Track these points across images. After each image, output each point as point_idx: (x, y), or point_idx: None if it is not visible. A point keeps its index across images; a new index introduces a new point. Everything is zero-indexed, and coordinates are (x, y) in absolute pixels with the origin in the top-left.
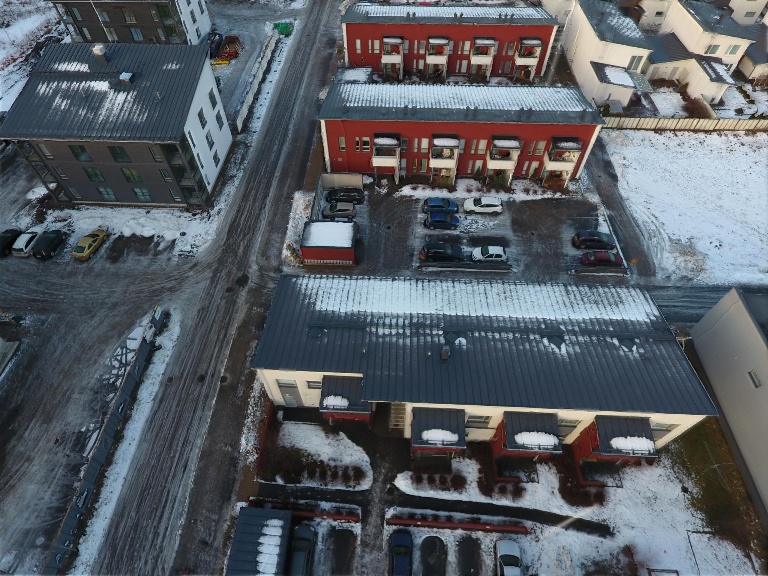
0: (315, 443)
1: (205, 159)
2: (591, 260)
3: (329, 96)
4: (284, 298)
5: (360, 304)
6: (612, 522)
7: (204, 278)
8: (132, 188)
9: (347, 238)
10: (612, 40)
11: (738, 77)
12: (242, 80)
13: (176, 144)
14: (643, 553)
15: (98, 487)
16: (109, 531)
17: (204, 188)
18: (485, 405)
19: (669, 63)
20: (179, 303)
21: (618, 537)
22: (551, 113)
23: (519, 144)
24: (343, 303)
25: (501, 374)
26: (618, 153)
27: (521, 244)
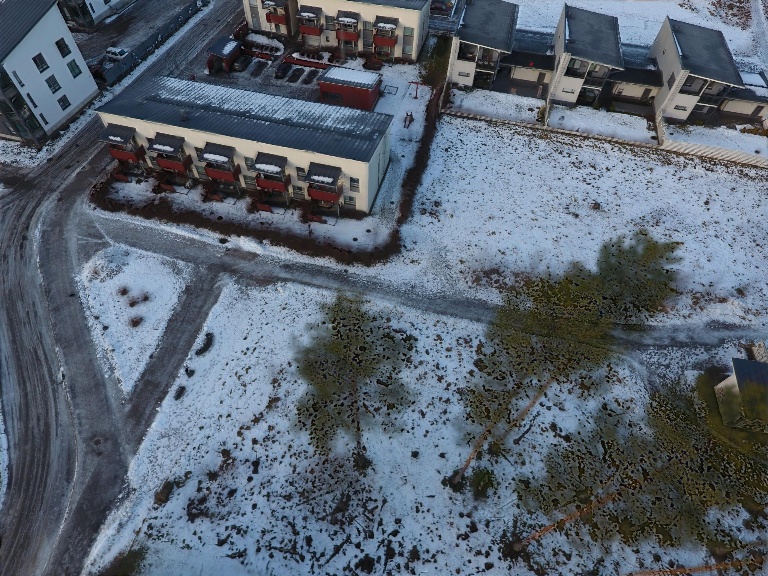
0: (262, 40)
1: None
2: (432, 7)
3: None
4: None
5: None
6: None
7: None
8: None
9: None
10: None
11: None
12: None
13: None
14: (387, 82)
15: (166, 40)
16: (168, 50)
17: None
18: None
19: None
20: None
21: None
22: None
23: None
24: None
25: None
26: None
27: None
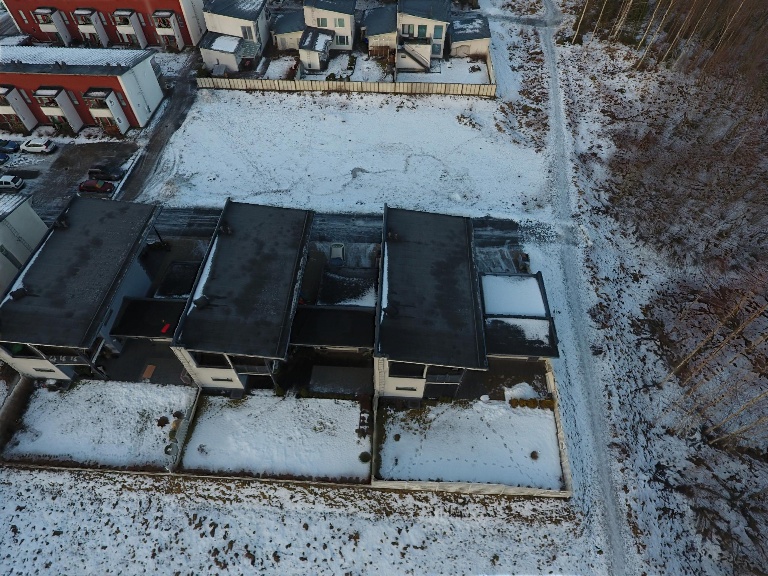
0: None
1: None
2: (81, 187)
3: None
4: None
5: None
6: None
7: None
8: None
9: None
10: (216, 12)
11: (363, 49)
12: None
13: None
14: None
15: None
16: None
17: None
18: None
19: (287, 34)
20: None
21: None
22: None
23: (58, 93)
24: None
25: None
26: (197, 108)
27: (48, 176)
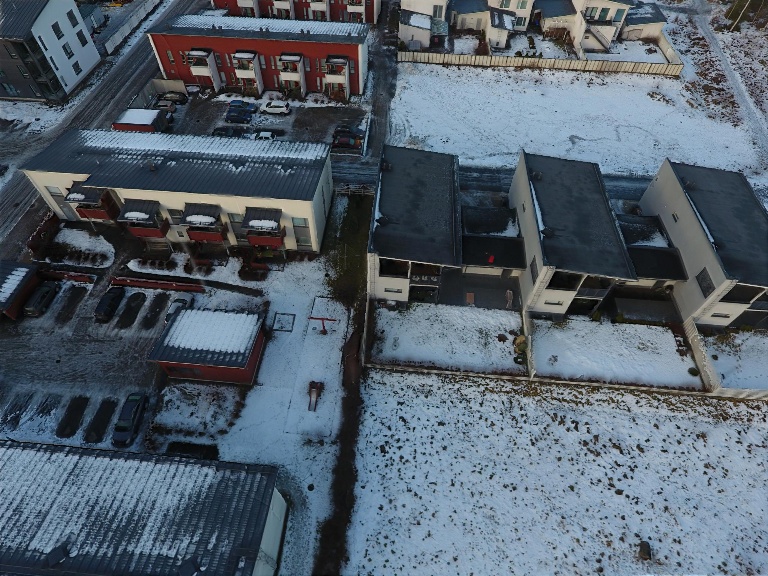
0: (80, 241)
1: (61, 64)
2: (335, 143)
3: (166, 21)
4: (66, 139)
5: (117, 144)
6: (266, 289)
7: (42, 147)
8: (1, 83)
9: (150, 119)
10: None
11: (536, 30)
12: (128, 18)
13: (24, 43)
14: (278, 305)
15: None
16: None
17: (60, 87)
18: (161, 190)
19: (471, 14)
20: (17, 161)
21: (265, 297)
22: (328, 36)
23: (300, 59)
24: (106, 143)
25: (185, 178)
26: (404, 79)
27: (294, 135)
